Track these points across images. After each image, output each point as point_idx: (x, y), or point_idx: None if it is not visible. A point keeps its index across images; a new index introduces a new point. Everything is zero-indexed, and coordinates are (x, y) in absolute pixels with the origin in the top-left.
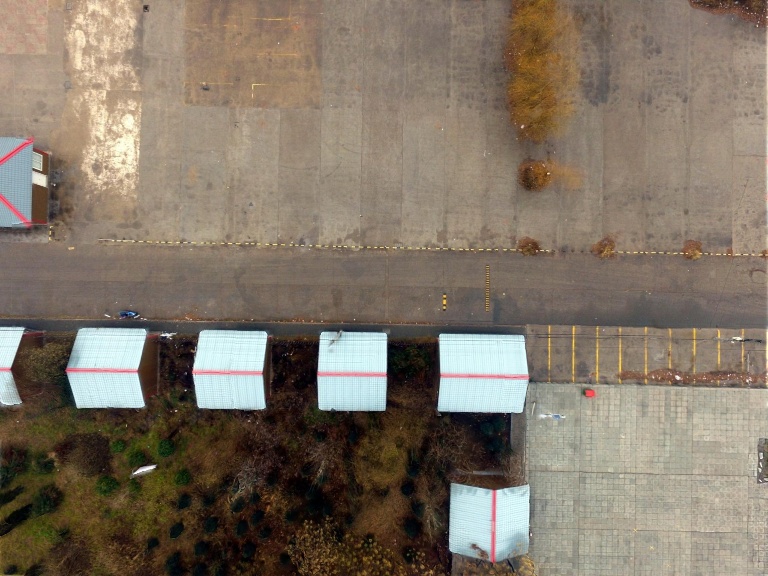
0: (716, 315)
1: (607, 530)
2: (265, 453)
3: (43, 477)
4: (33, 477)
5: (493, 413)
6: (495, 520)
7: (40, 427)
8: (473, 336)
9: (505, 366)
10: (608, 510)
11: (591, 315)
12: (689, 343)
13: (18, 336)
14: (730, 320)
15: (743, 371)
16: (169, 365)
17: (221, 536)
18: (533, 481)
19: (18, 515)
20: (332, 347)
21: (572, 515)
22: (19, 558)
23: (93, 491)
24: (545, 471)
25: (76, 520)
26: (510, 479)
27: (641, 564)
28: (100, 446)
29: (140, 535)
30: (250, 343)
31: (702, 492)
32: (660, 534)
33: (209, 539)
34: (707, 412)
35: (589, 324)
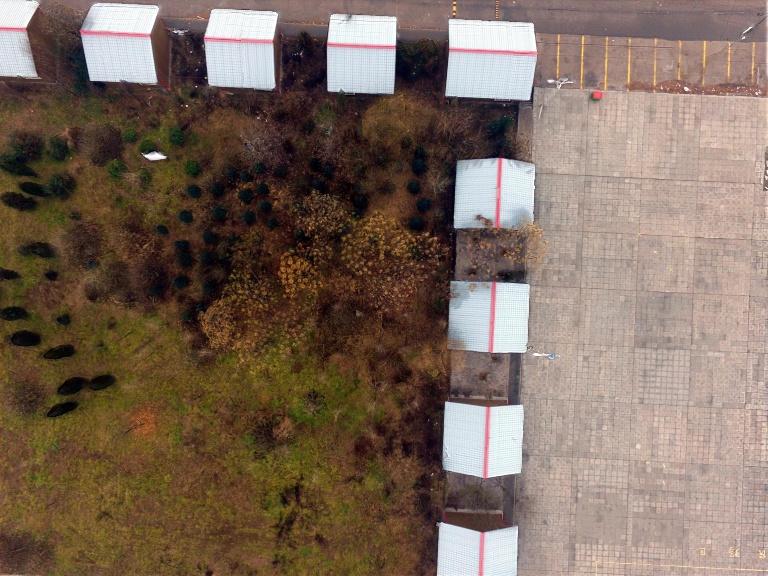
0: (727, 28)
1: (611, 233)
2: (274, 149)
3: (56, 165)
4: (47, 165)
5: (500, 119)
6: (500, 187)
7: (54, 117)
8: (482, 22)
9: (514, 44)
10: (612, 214)
11: (601, 25)
12: (699, 55)
13: (33, 6)
14: (741, 33)
15: (753, 84)
16: (180, 60)
17: (229, 229)
18: (538, 184)
19: (32, 184)
20: (342, 25)
21: (576, 218)
22: (32, 242)
23: (105, 180)
24: (551, 174)
25: (88, 208)
26: (516, 151)
27: (644, 268)
28: (112, 137)
29: (150, 225)
30: (261, 19)
31: (707, 198)
32: (664, 239)
33: (217, 232)
34: (715, 119)
35: (599, 34)
